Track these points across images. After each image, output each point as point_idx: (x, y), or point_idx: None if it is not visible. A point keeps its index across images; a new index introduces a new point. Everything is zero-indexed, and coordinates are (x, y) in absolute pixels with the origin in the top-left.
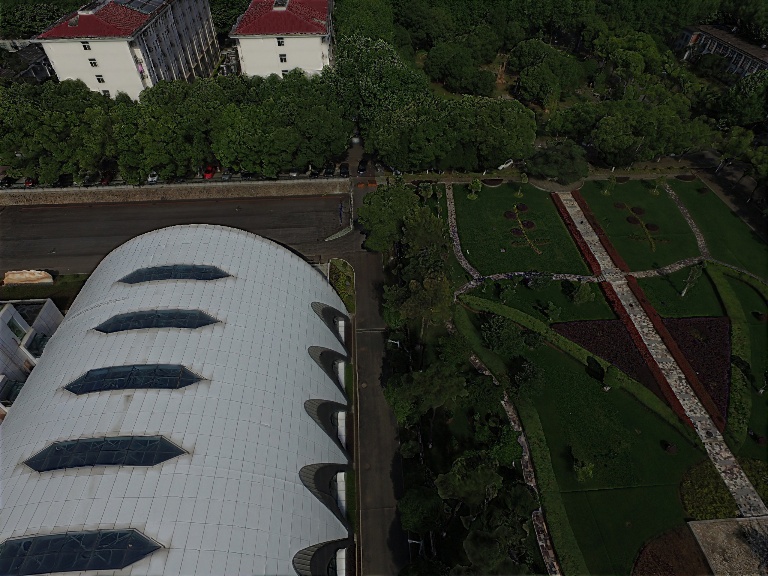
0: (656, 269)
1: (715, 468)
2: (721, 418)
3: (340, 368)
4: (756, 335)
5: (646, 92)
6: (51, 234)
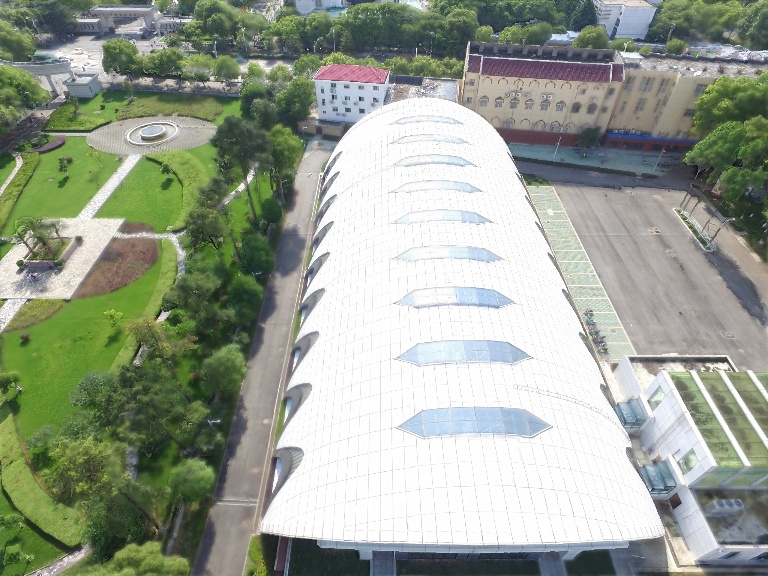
0: None
1: (7, 325)
2: None
3: None
4: None
5: None
6: None
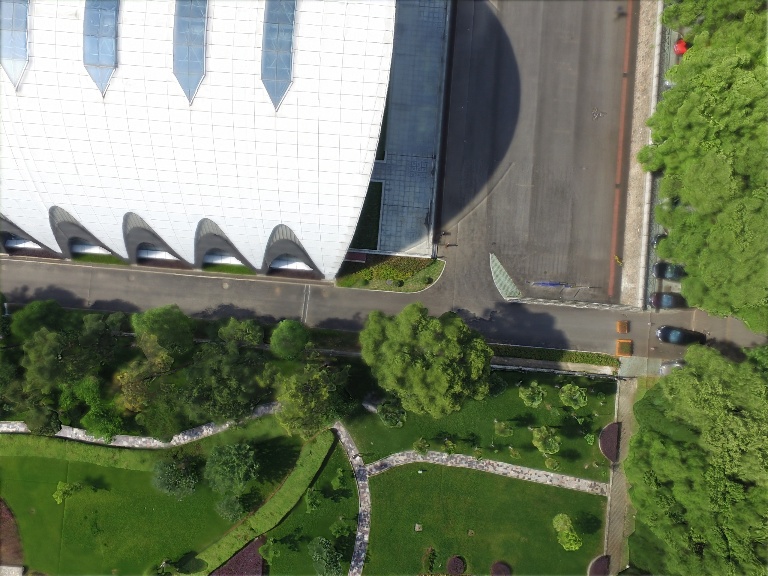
0: None
1: None
2: None
3: None
4: None
5: None
6: None
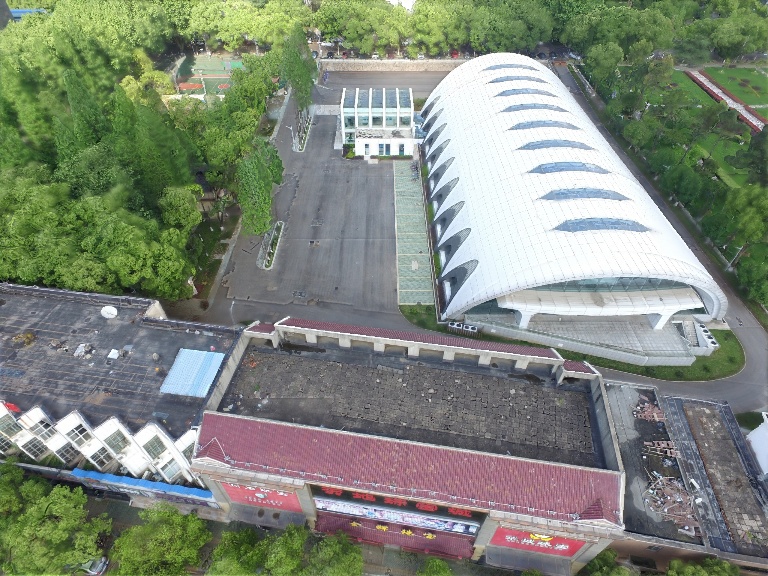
0: (762, 105)
1: None
2: None
3: None
4: None
5: (743, 19)
6: (370, 83)
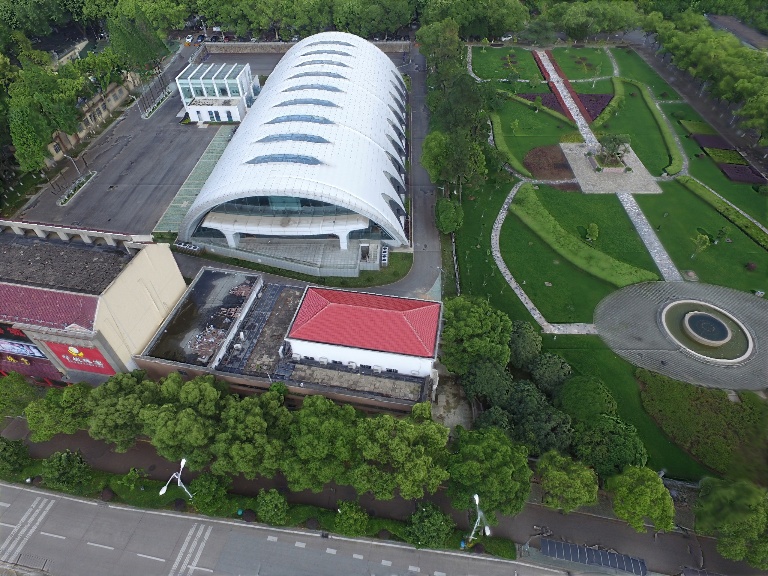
0: (583, 79)
1: (580, 132)
2: (590, 120)
3: None
4: (627, 101)
5: (611, 3)
6: (242, 63)
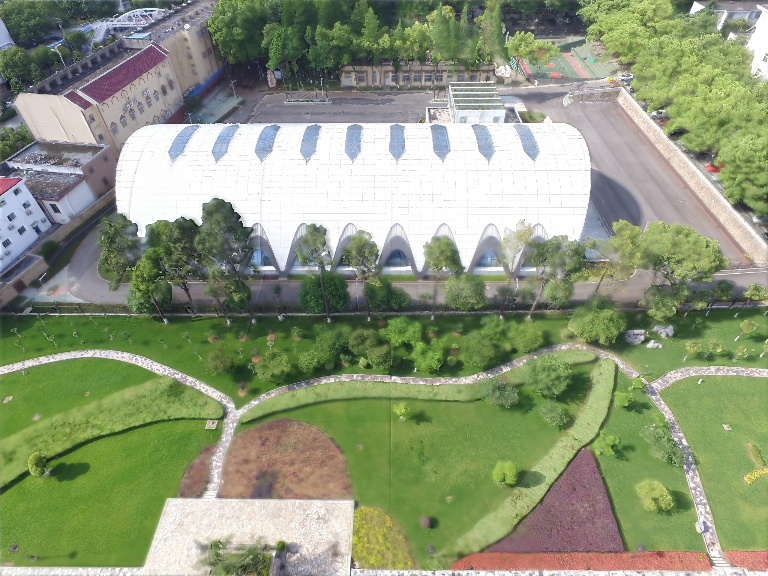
0: None
1: (404, 568)
2: None
3: (498, 268)
4: None
5: None
6: (597, 124)
